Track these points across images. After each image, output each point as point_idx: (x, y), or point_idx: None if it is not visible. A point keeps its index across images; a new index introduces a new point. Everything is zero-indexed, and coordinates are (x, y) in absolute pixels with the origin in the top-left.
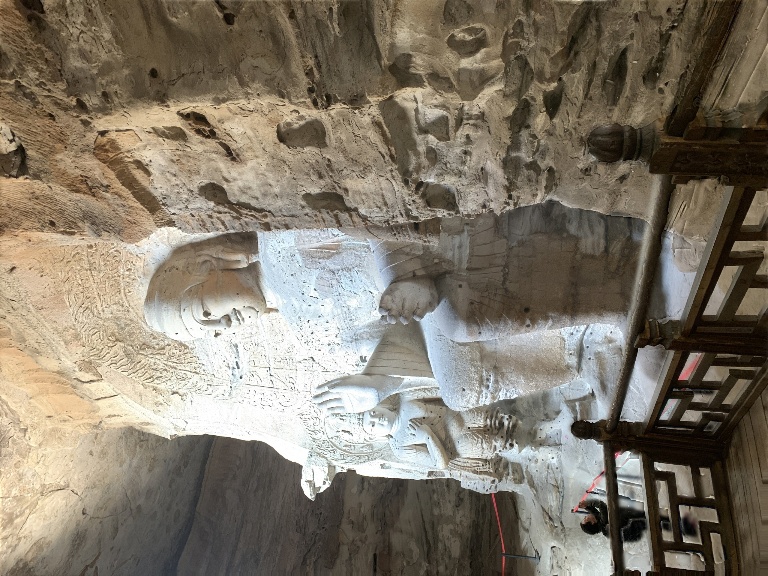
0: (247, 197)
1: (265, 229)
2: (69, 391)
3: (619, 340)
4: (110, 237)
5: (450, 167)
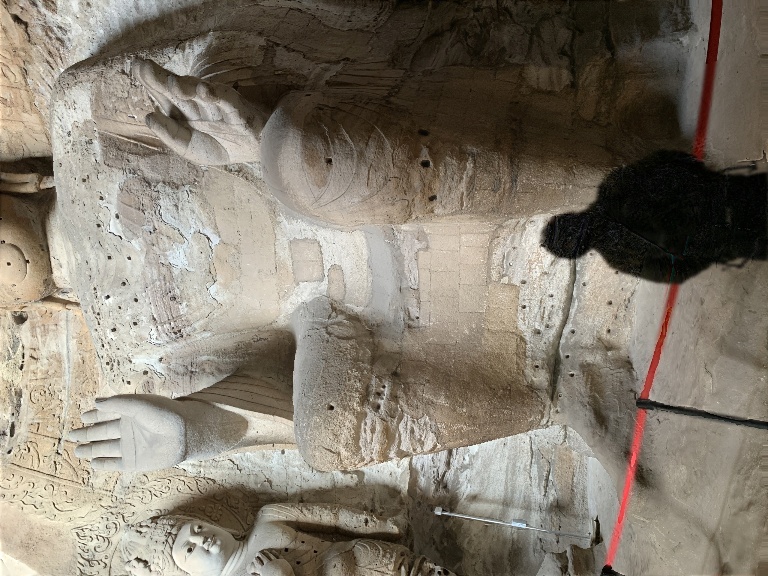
0: None
1: None
2: None
3: (625, 347)
4: None
5: None
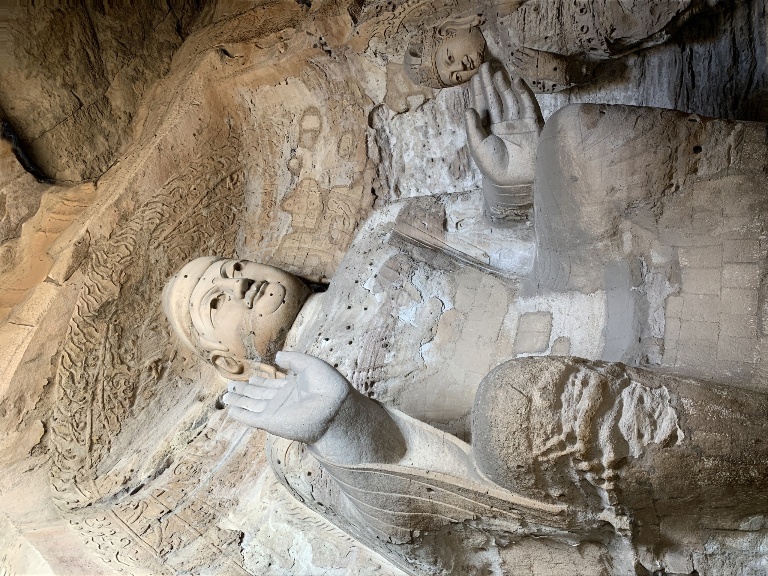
0: None
1: None
2: None
3: None
4: (309, 19)
5: None
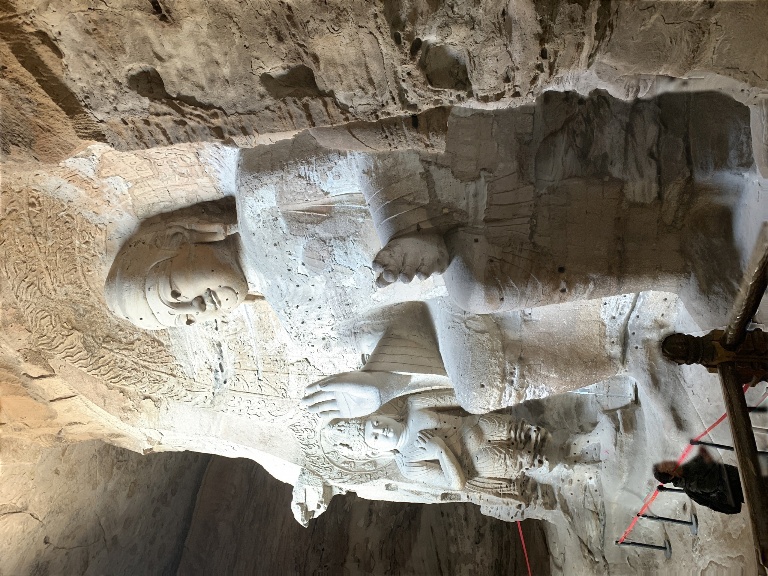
0: (190, 87)
1: (217, 137)
2: (22, 392)
3: (672, 325)
4: (21, 154)
5: (458, 11)
